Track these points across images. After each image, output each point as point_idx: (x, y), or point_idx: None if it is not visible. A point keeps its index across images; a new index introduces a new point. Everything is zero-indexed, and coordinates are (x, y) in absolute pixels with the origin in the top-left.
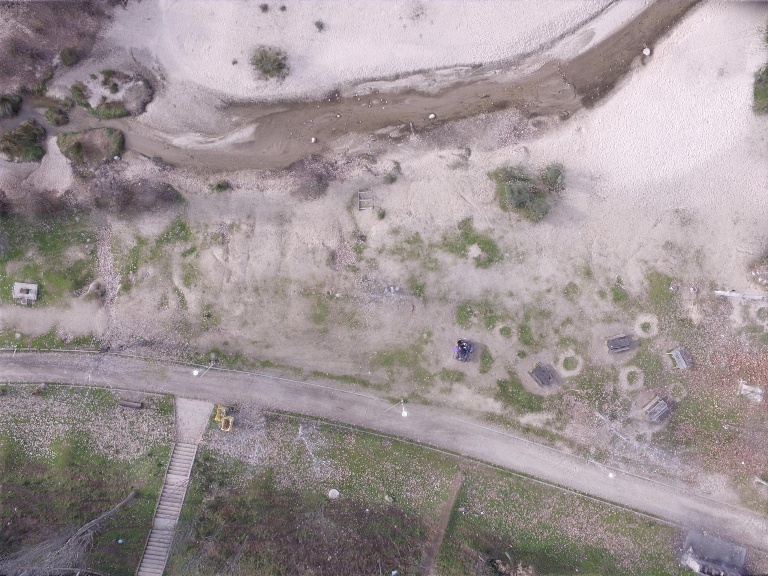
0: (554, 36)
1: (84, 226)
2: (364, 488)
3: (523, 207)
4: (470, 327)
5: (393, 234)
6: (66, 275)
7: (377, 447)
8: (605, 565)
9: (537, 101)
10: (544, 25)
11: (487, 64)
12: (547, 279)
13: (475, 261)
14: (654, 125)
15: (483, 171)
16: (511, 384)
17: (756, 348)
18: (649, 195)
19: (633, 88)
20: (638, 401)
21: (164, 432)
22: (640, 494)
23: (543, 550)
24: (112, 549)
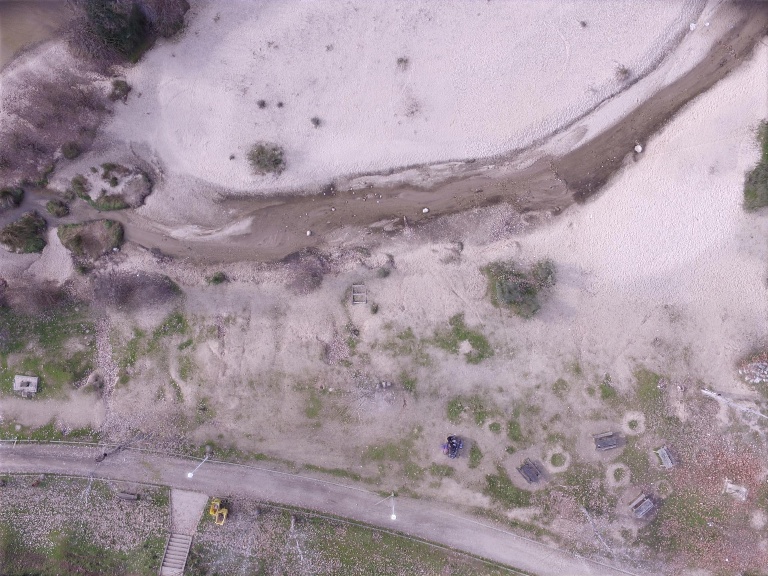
0: (547, 133)
1: (83, 317)
2: None
3: (514, 303)
4: (460, 423)
5: (386, 329)
6: (65, 367)
7: (368, 540)
8: None
9: (529, 196)
10: (537, 123)
11: (480, 160)
12: (536, 375)
13: (466, 357)
14: (644, 222)
15: (475, 266)
16: (500, 479)
17: (741, 447)
18: (639, 291)
19: (624, 185)
20: (624, 497)
21: (160, 523)
22: None
23: None
24: None
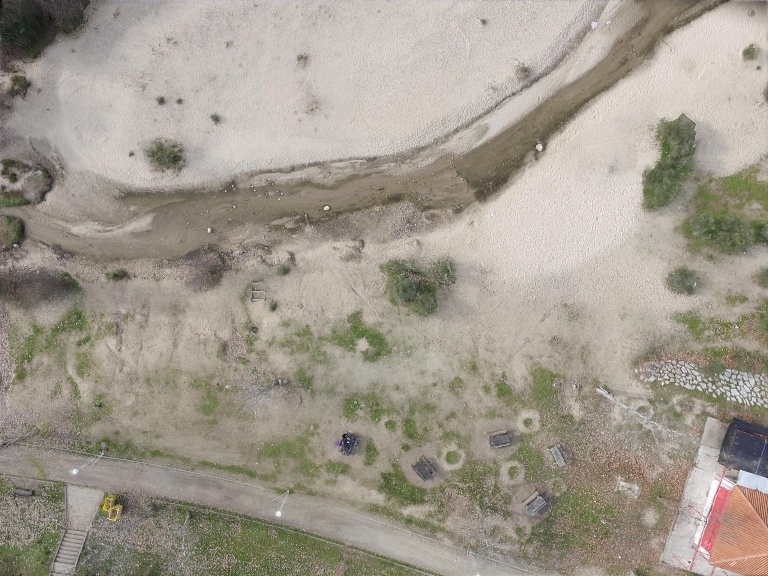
0: (448, 131)
1: None
2: (249, 575)
3: (412, 301)
4: (356, 420)
5: (283, 326)
6: None
7: (263, 536)
8: None
9: (430, 194)
10: (437, 120)
11: (381, 157)
12: (433, 373)
13: (363, 355)
14: (544, 221)
15: (375, 264)
16: (395, 477)
17: (635, 446)
18: (538, 290)
19: (525, 183)
20: (519, 495)
21: (55, 519)
22: None
23: None
24: None
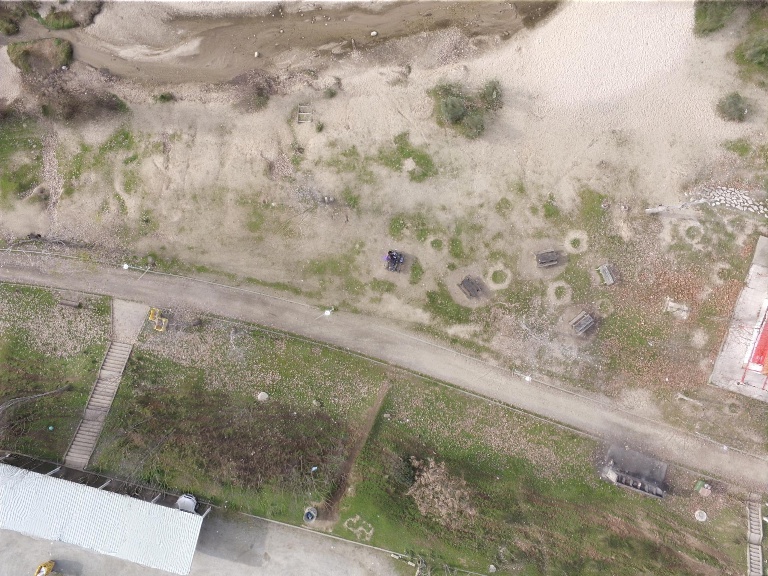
0: None
1: (31, 133)
2: (293, 392)
3: (459, 124)
4: (402, 239)
5: (330, 147)
6: (11, 178)
7: (307, 353)
8: (526, 474)
9: (478, 20)
10: None
11: None
12: (480, 194)
13: (409, 175)
14: (593, 46)
15: (422, 88)
16: (440, 296)
17: (684, 266)
18: (586, 116)
19: (574, 9)
20: (565, 316)
21: (101, 331)
22: (564, 407)
23: (466, 458)
24: (42, 434)
